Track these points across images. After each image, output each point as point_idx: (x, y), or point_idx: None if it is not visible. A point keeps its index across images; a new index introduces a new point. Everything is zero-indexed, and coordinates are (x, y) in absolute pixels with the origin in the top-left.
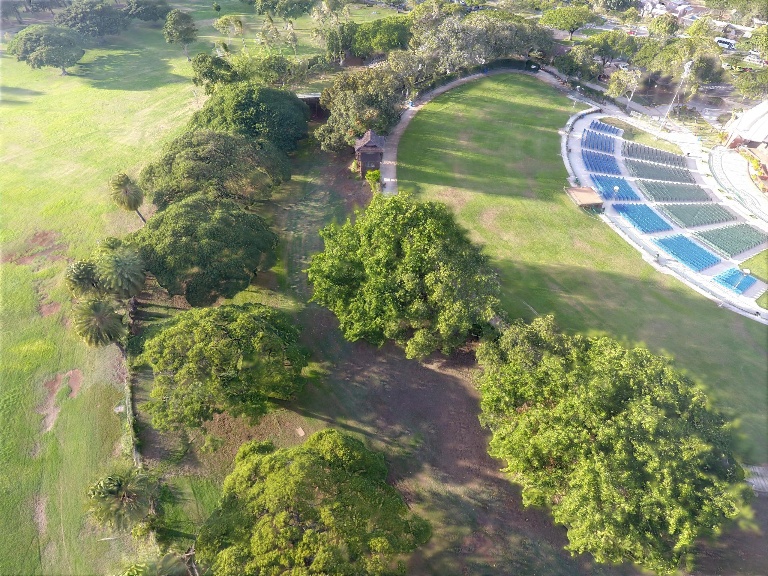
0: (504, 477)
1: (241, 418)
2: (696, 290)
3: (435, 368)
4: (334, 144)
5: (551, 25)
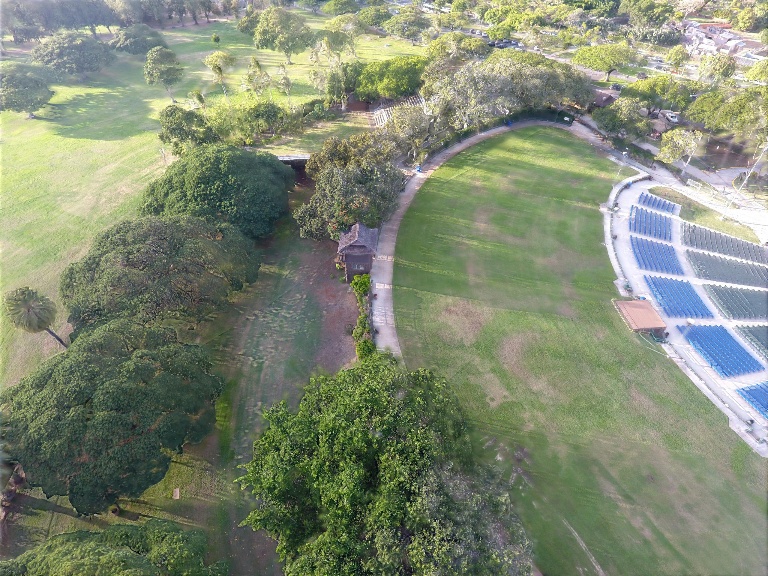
0: None
1: None
2: None
3: None
4: (316, 232)
5: (586, 65)
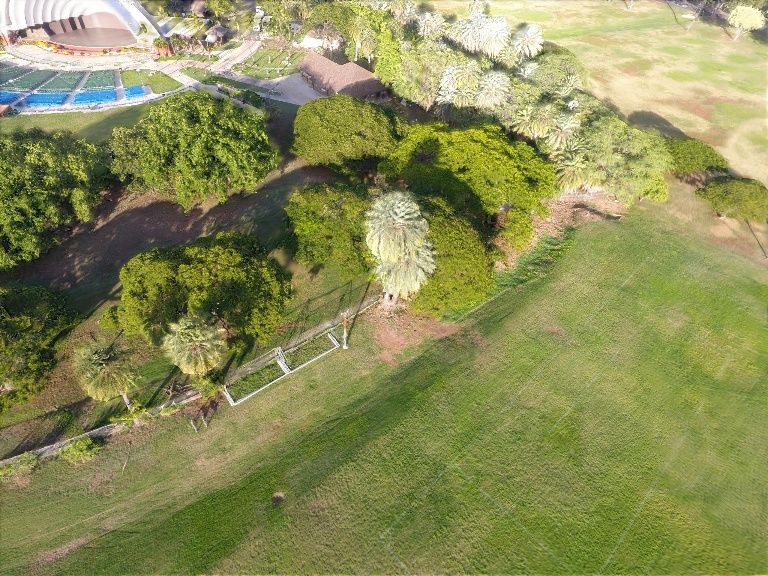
0: (203, 214)
1: (56, 368)
2: (130, 105)
3: (102, 224)
4: None
5: None
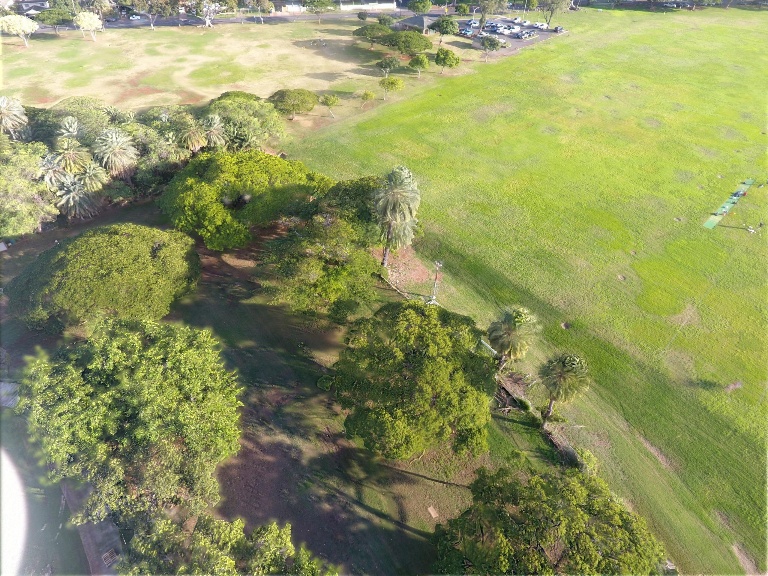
0: None
1: None
2: None
3: None
4: None
5: None
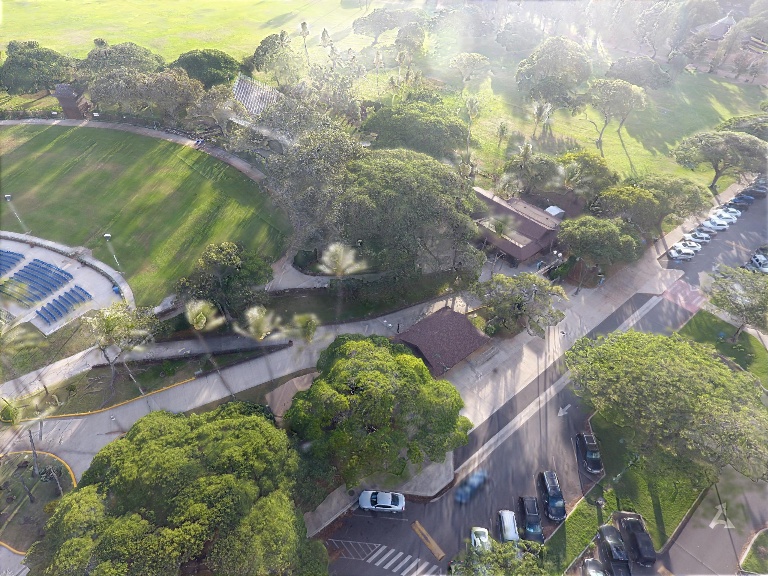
0: None
1: None
2: None
3: None
4: None
5: (585, 339)
